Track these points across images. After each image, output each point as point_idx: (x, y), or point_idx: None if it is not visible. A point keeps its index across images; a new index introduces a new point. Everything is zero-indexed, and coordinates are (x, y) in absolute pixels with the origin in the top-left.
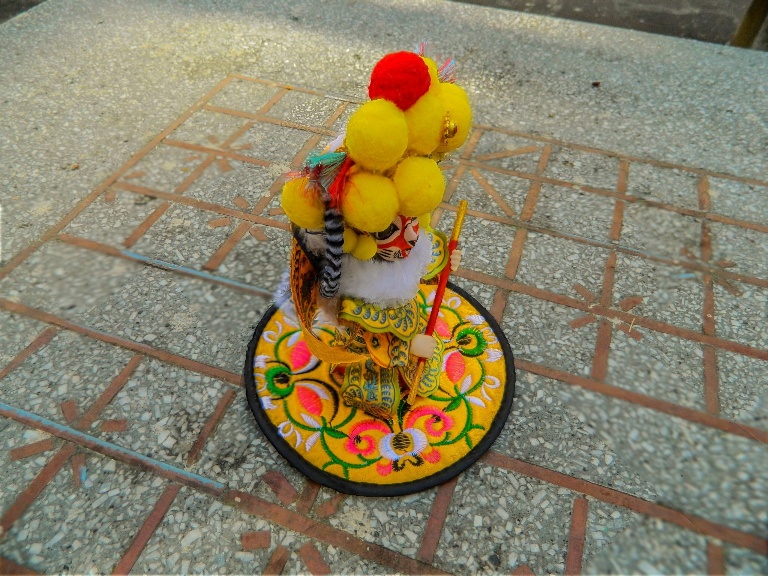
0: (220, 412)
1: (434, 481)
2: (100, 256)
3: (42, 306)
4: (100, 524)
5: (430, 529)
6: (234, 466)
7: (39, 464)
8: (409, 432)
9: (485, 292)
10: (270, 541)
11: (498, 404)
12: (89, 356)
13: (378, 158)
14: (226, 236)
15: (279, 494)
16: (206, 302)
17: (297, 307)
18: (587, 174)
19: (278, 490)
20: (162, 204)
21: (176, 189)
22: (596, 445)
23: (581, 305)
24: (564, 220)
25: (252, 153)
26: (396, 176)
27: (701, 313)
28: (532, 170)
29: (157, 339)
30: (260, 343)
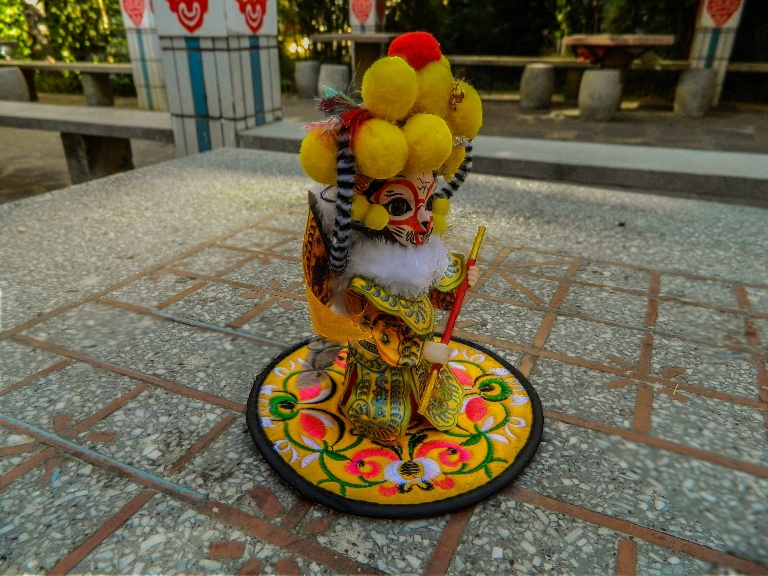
0: (215, 433)
1: (445, 505)
2: (132, 314)
3: (65, 345)
4: (56, 520)
5: (437, 556)
6: (219, 480)
7: (12, 463)
8: (420, 461)
9: (511, 356)
10: (243, 552)
11: (523, 441)
12: (96, 382)
13: (388, 96)
14: (255, 305)
15: (263, 508)
16: (223, 349)
17: (305, 272)
18: (617, 280)
19: (263, 504)
20: (201, 283)
21: (216, 274)
22: (643, 490)
23: (617, 371)
24: (595, 309)
25: (292, 254)
26: (406, 126)
27: (755, 385)
28: (561, 275)
29: (167, 373)
30: (270, 375)
